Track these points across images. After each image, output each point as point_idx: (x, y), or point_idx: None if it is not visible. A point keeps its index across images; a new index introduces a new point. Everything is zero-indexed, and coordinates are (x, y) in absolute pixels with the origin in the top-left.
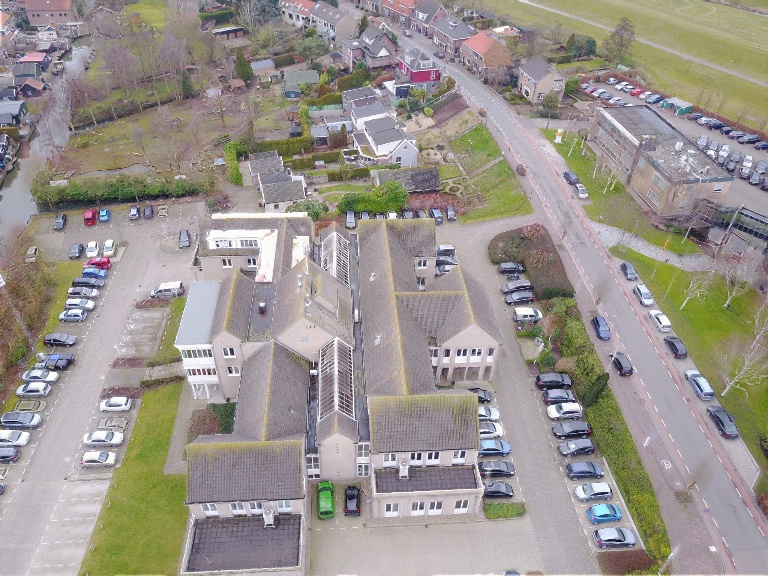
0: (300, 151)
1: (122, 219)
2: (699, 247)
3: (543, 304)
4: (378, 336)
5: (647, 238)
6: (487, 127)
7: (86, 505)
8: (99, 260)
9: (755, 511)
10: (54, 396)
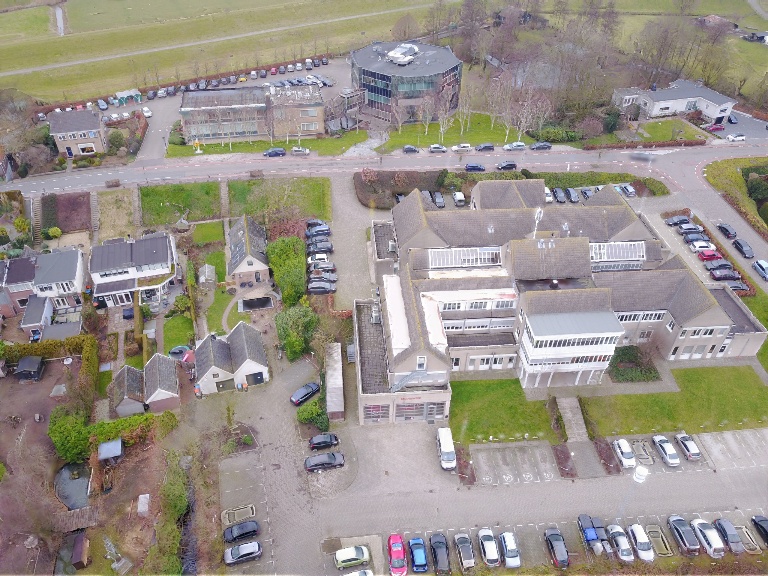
0: (98, 359)
1: (256, 573)
2: (359, 130)
3: (445, 191)
4: (566, 224)
5: (358, 142)
6: (155, 183)
7: (729, 443)
8: (400, 544)
9: (593, 151)
10: (635, 522)
